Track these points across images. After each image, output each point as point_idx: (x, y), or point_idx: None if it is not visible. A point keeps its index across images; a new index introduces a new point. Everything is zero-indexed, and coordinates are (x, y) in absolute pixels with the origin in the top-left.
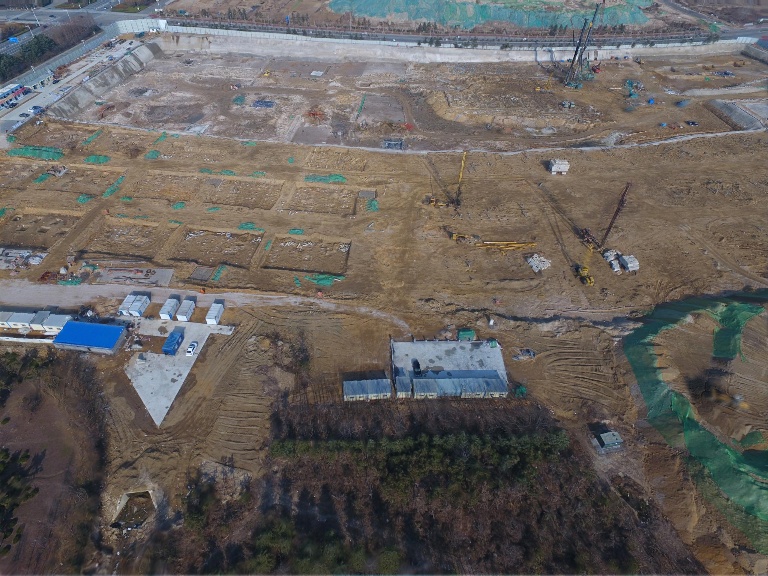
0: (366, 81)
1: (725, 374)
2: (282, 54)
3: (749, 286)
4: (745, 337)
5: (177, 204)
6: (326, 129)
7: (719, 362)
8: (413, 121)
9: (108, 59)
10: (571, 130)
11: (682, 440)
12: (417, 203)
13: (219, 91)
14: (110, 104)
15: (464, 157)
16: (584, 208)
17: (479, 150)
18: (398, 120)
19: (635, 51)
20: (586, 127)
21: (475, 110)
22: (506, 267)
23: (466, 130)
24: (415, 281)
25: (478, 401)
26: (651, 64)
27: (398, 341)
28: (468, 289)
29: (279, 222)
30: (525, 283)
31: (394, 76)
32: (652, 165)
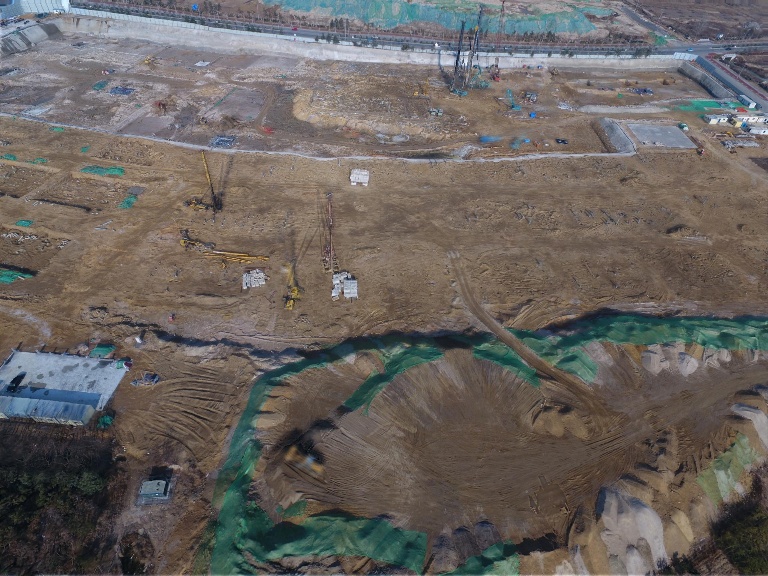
0: (245, 74)
1: (327, 428)
2: (178, 42)
3: (472, 327)
4: (390, 386)
5: None
6: (166, 120)
7: (338, 413)
8: (262, 118)
9: None
10: (424, 139)
11: (221, 500)
12: (178, 204)
13: (88, 75)
14: None
15: None
16: (357, 224)
17: (293, 153)
18: (248, 116)
19: (552, 61)
20: (441, 137)
21: (333, 111)
22: (216, 281)
23: (311, 132)
24: (103, 287)
25: (51, 427)
26: (567, 76)
27: (24, 350)
28: (154, 301)
29: (16, 212)
30: (220, 300)
31: (278, 71)
32: (473, 183)
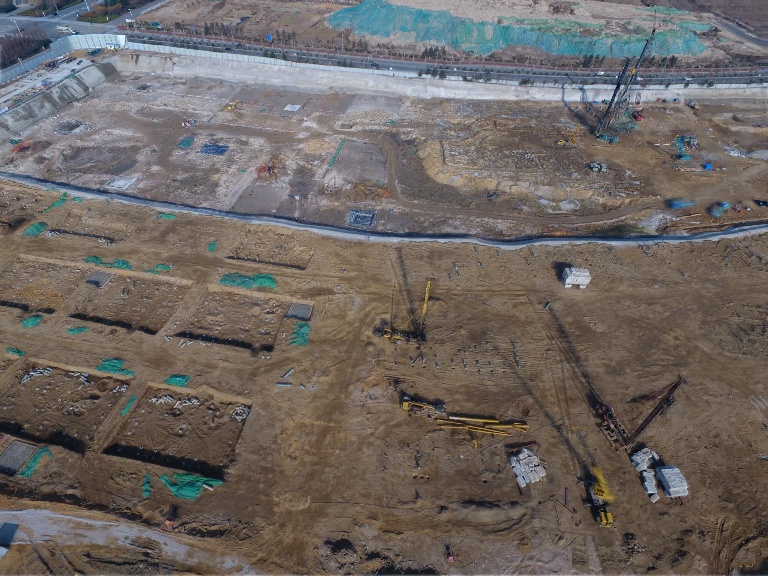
0: (348, 121)
1: None
2: (256, 81)
3: None
4: None
5: (28, 320)
6: (282, 190)
7: None
8: (395, 183)
9: (41, 84)
10: (599, 206)
11: None
12: (365, 333)
13: (166, 129)
14: (27, 143)
15: (428, 287)
16: (607, 354)
17: (469, 240)
18: (376, 180)
19: (688, 92)
20: (619, 203)
21: (476, 170)
22: (476, 473)
23: (461, 199)
24: (328, 497)
25: None
26: (708, 109)
27: None
28: (409, 520)
29: (160, 359)
30: (501, 513)
31: (384, 115)
32: (709, 277)
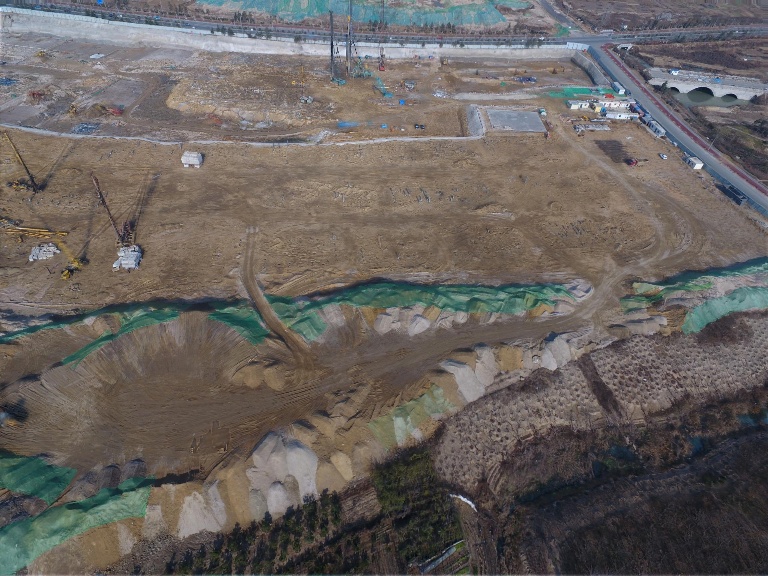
0: (134, 66)
1: (28, 380)
2: (79, 36)
3: (236, 295)
4: (110, 344)
5: None
6: (38, 109)
7: (50, 367)
8: (133, 107)
9: None
10: (286, 126)
11: None
12: (2, 184)
13: None
14: None
15: (8, 138)
16: (172, 202)
17: (140, 138)
18: None
19: (444, 51)
20: (302, 123)
21: (204, 100)
22: (7, 254)
23: (177, 119)
24: None
25: None
26: (457, 65)
27: None
28: None
29: None
30: (1, 271)
31: (168, 63)
32: (306, 165)
